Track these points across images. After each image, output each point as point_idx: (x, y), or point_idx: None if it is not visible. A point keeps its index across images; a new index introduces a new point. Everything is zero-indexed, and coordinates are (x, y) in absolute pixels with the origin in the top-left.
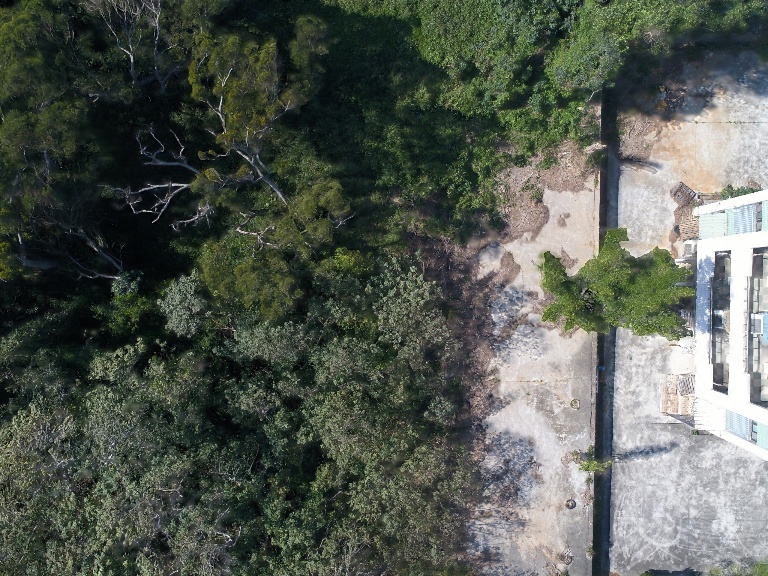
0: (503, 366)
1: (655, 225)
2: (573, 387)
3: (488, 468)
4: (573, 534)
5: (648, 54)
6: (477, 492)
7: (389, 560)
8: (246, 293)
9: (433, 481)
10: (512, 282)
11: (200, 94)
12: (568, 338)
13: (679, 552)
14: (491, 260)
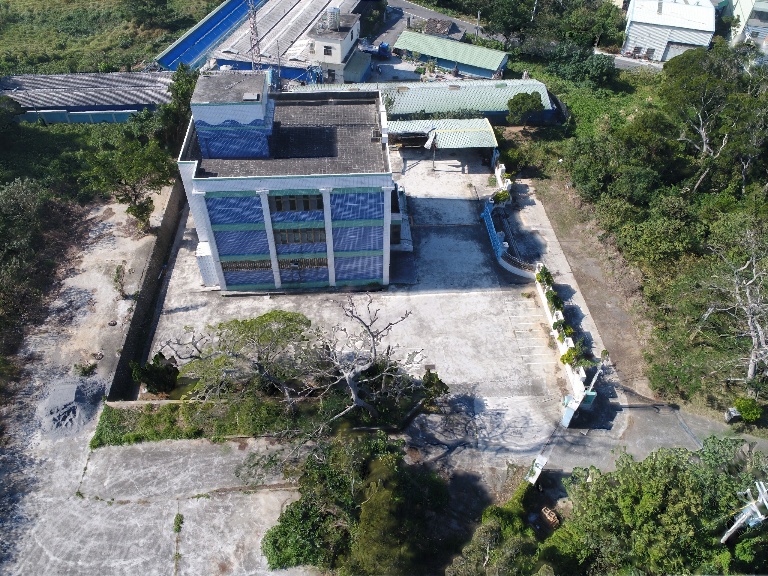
0: (87, 254)
1: None
2: (133, 263)
3: (56, 305)
4: (109, 341)
5: None
6: (41, 319)
7: None
8: None
9: (9, 313)
10: (108, 219)
11: None
12: (136, 241)
13: None
14: (98, 211)
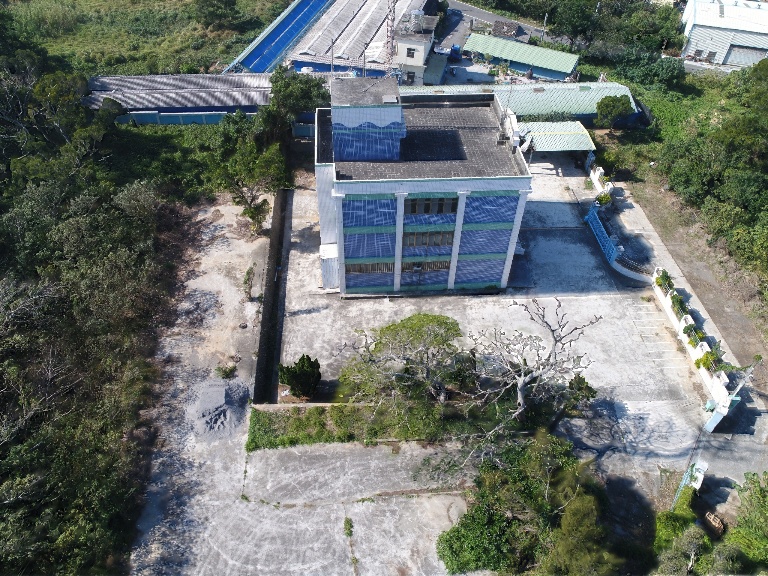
0: (205, 256)
1: (315, 209)
2: (251, 265)
3: (183, 307)
4: (243, 344)
5: (310, 153)
6: (172, 321)
7: (80, 324)
8: (31, 166)
9: (139, 315)
10: (217, 221)
11: (39, 92)
12: (250, 243)
13: (334, 367)
14: (206, 213)
